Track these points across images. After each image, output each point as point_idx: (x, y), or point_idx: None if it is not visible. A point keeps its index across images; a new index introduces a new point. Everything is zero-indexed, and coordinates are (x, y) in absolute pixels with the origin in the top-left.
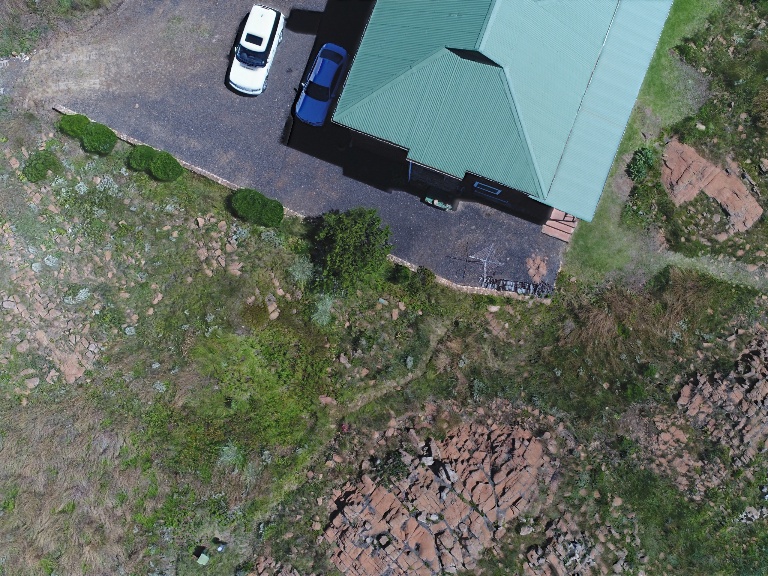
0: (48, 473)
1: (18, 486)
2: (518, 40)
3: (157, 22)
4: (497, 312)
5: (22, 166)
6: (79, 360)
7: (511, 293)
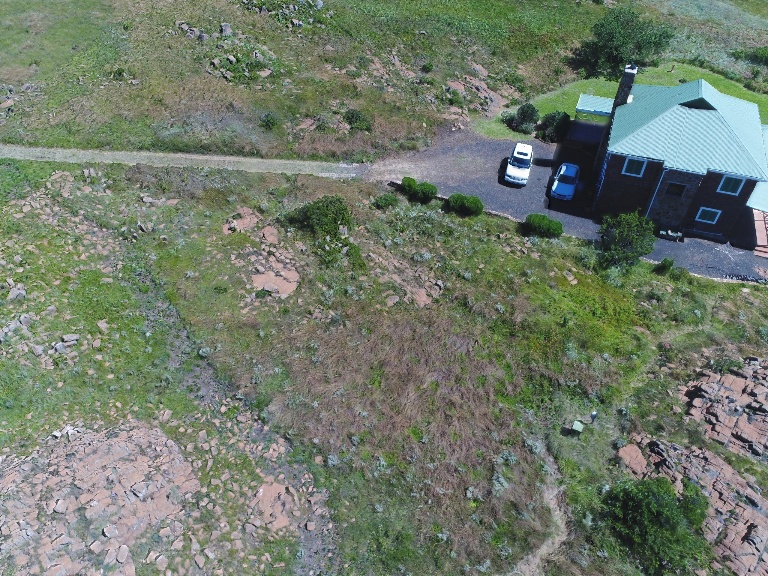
0: (411, 359)
1: (384, 367)
2: (719, 102)
3: (450, 158)
4: (749, 293)
5: (372, 202)
6: (428, 292)
7: (754, 283)
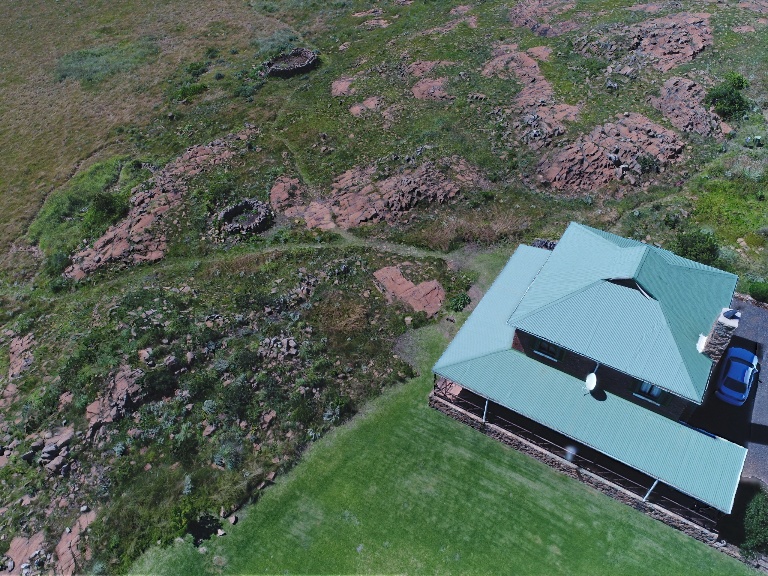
0: None
1: None
2: None
3: None
4: None
5: None
6: None
7: None
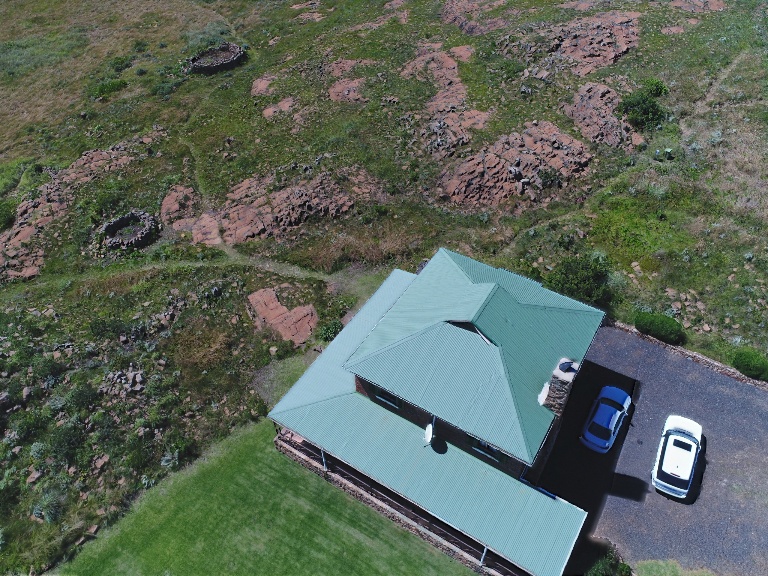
0: None
1: None
2: None
3: None
4: None
5: None
6: None
7: None
